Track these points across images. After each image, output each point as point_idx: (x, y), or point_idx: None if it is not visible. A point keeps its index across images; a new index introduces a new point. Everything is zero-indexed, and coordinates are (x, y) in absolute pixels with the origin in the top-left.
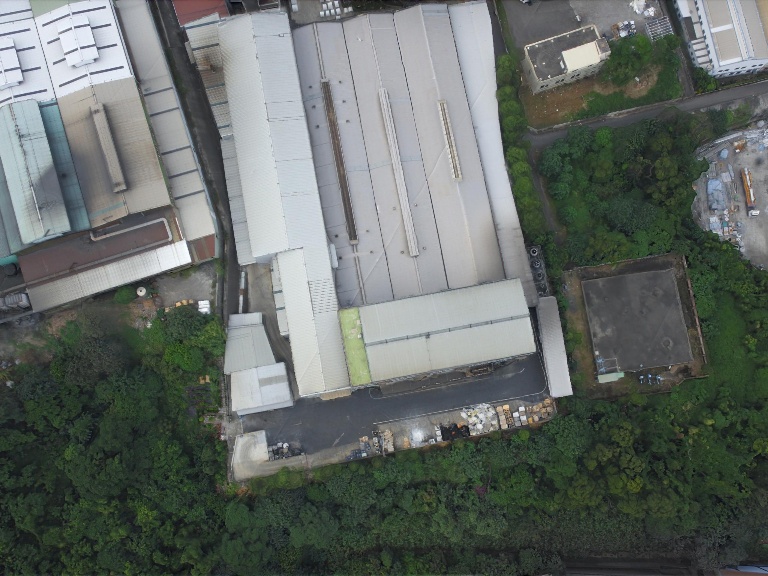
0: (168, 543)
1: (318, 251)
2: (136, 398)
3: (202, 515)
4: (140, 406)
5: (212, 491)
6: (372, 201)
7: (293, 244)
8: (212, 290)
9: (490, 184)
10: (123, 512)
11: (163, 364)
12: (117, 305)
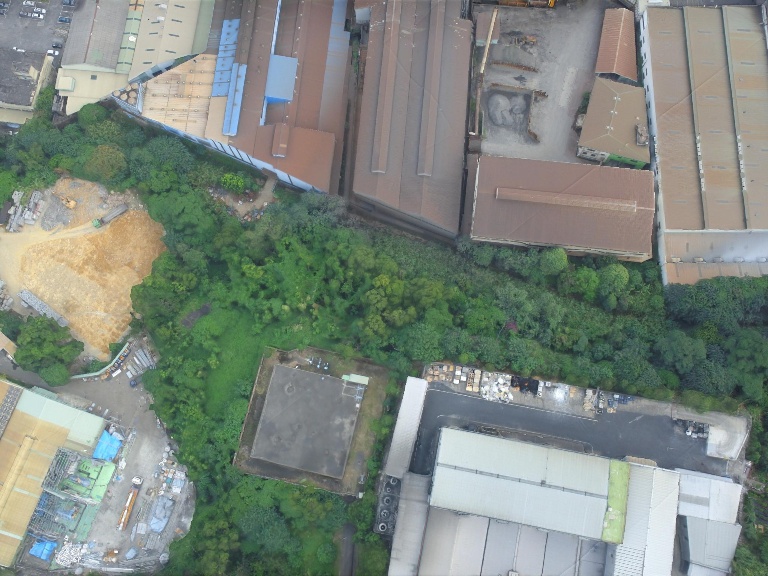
0: None
1: None
2: None
3: None
4: None
5: (767, 418)
6: None
7: None
8: None
9: None
10: None
11: None
12: None
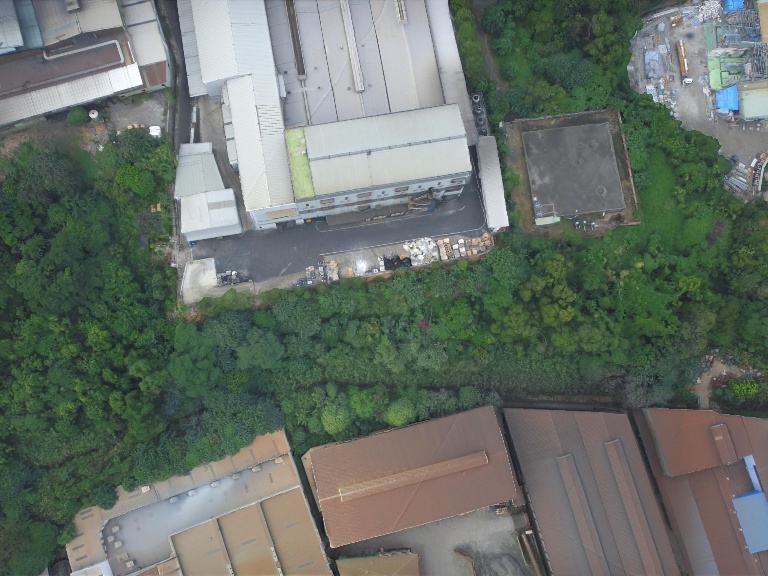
0: (118, 363)
1: (266, 78)
2: (88, 222)
3: (152, 339)
4: (92, 229)
5: (162, 318)
6: (321, 42)
7: (242, 70)
8: (163, 117)
9: (435, 31)
10: (74, 334)
11: (114, 186)
12: (70, 128)
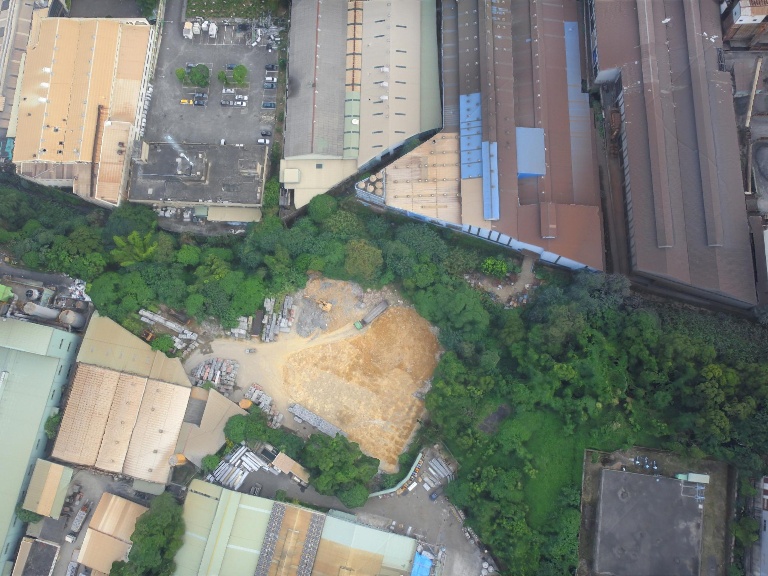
0: None
1: None
2: None
3: None
4: None
5: None
6: None
7: None
8: None
9: None
10: None
11: None
12: None
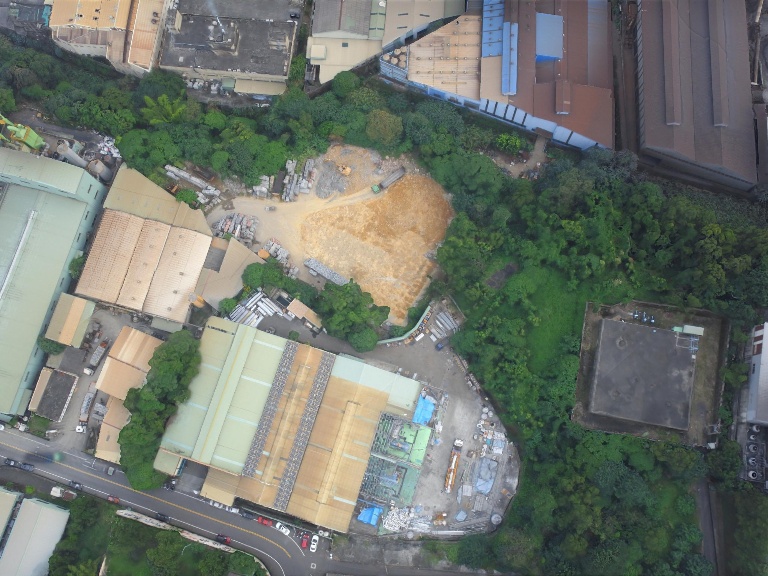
0: None
1: None
2: None
3: None
4: None
5: None
6: None
7: None
8: None
9: None
10: None
11: None
12: None
